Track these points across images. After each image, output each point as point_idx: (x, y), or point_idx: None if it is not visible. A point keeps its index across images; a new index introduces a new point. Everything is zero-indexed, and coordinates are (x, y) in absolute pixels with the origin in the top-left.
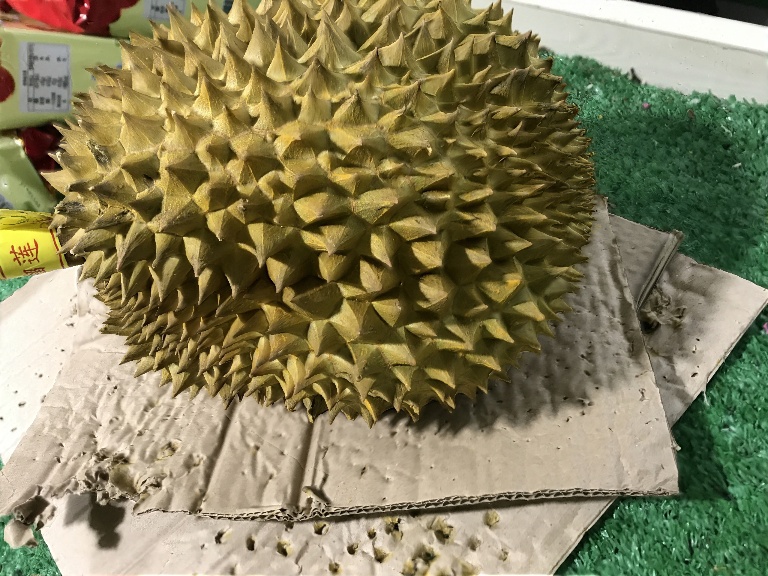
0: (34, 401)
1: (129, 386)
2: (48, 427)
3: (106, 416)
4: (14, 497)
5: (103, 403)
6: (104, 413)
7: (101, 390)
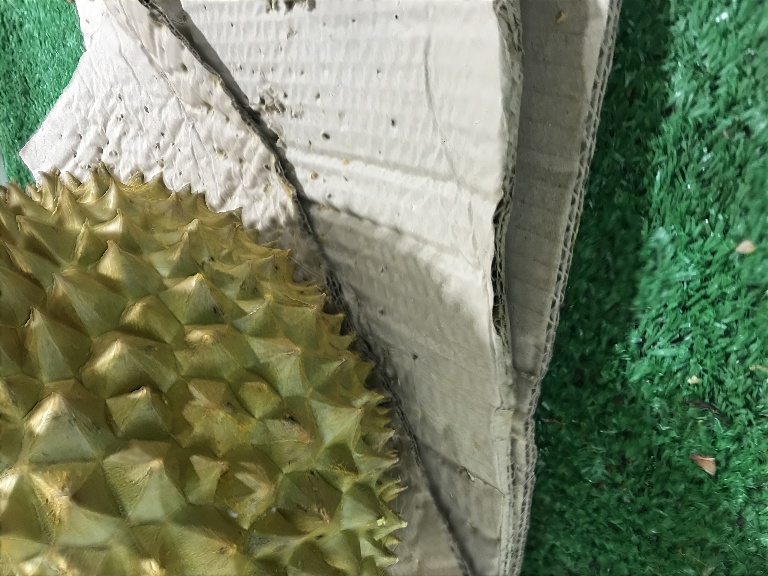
0: (98, 9)
1: (131, 126)
2: (75, 104)
3: (110, 141)
4: (43, 166)
5: (112, 122)
6: (110, 136)
7: (113, 105)
